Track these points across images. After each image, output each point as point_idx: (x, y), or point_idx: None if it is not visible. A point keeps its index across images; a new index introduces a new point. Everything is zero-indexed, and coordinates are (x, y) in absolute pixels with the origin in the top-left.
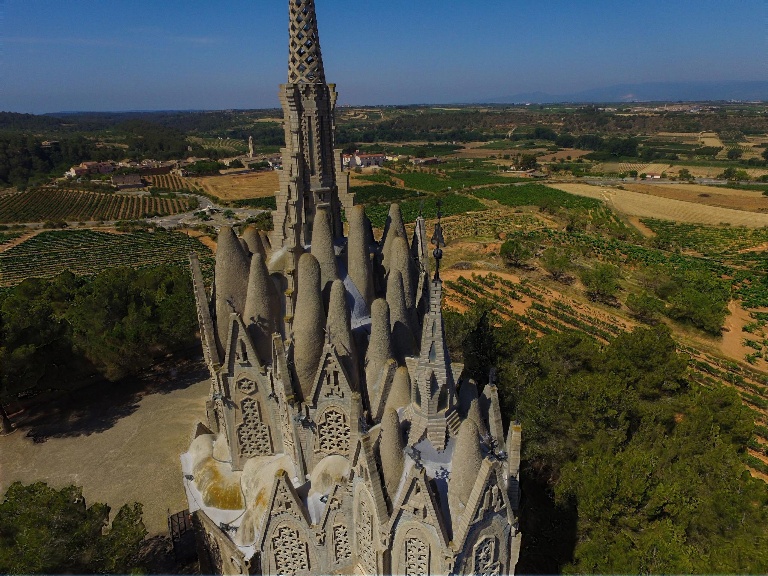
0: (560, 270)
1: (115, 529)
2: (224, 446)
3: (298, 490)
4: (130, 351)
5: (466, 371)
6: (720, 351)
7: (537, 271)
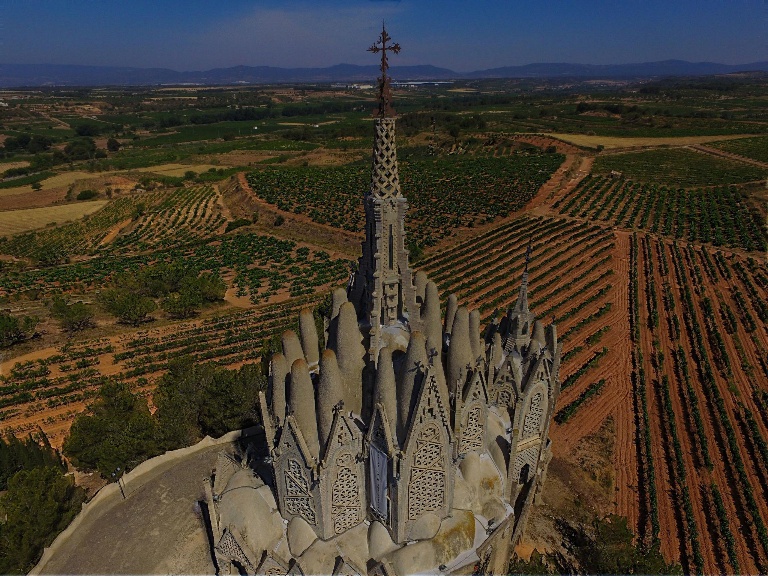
0: (87, 317)
1: None
2: (435, 517)
3: (503, 444)
4: None
5: None
6: (239, 307)
7: (46, 334)
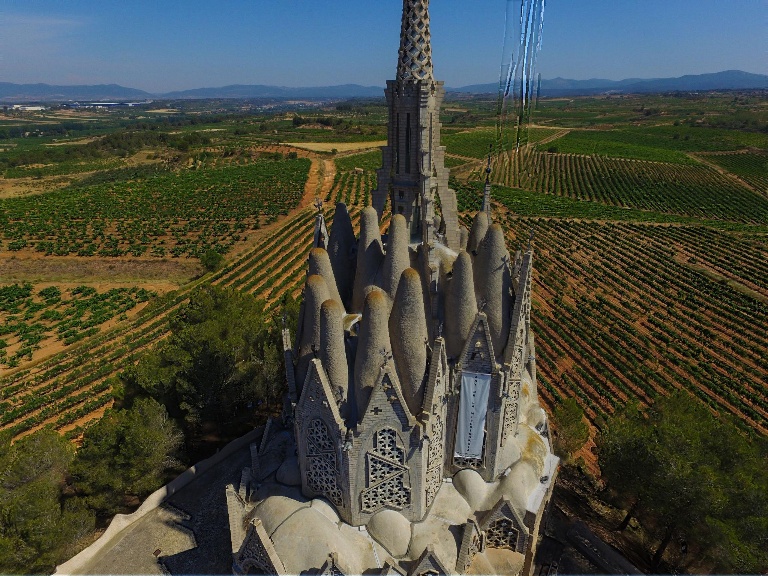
0: None
1: (626, 425)
2: None
3: None
4: None
5: (215, 418)
6: None
7: None
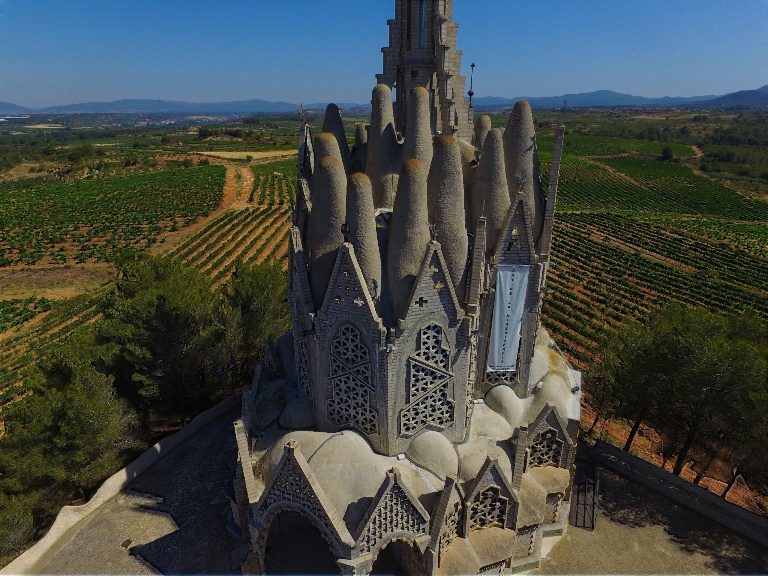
0: None
1: None
2: None
3: None
4: None
5: (177, 390)
6: None
7: None
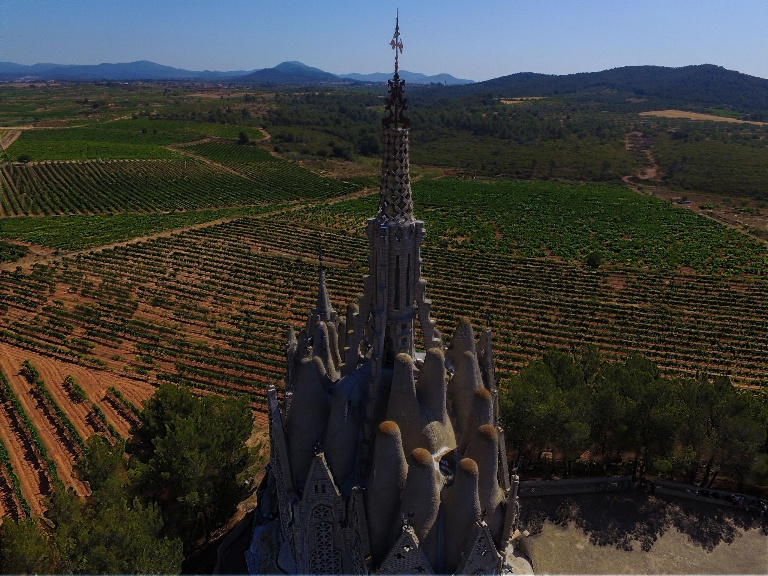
0: None
1: None
2: None
3: None
4: None
5: None
6: None
7: None
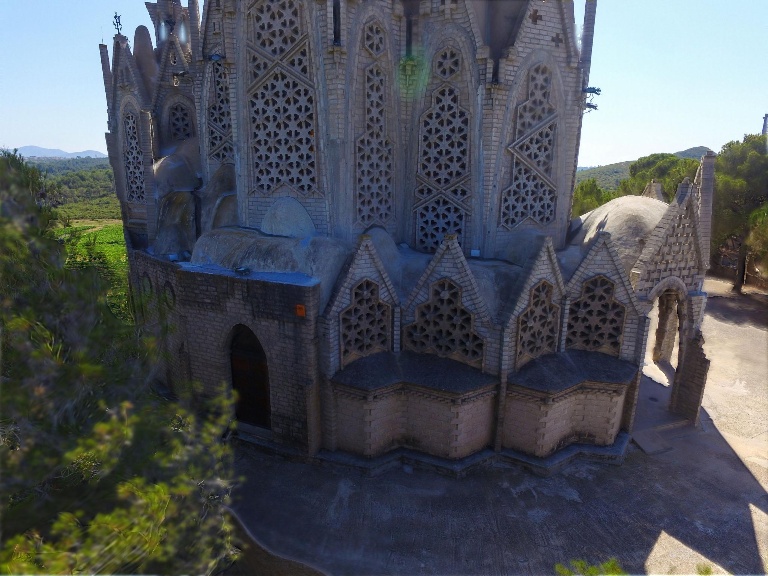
0: None
1: None
2: None
3: None
4: (766, 229)
5: None
6: None
7: None
